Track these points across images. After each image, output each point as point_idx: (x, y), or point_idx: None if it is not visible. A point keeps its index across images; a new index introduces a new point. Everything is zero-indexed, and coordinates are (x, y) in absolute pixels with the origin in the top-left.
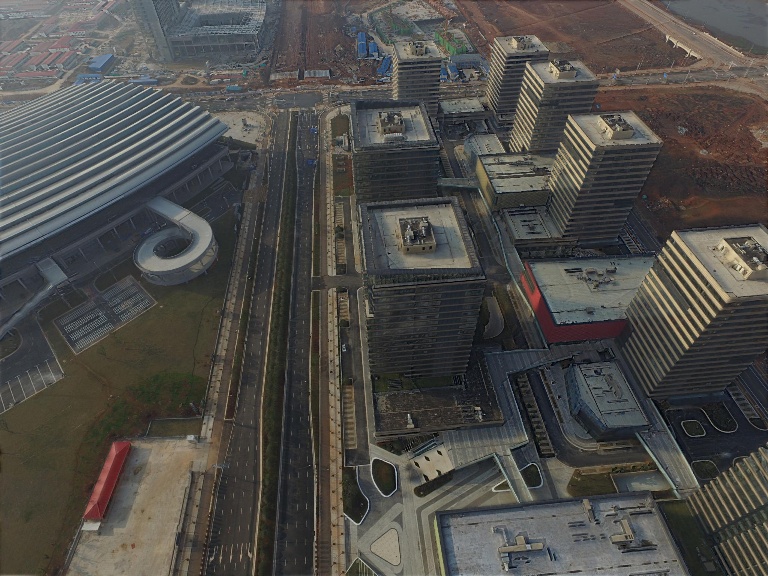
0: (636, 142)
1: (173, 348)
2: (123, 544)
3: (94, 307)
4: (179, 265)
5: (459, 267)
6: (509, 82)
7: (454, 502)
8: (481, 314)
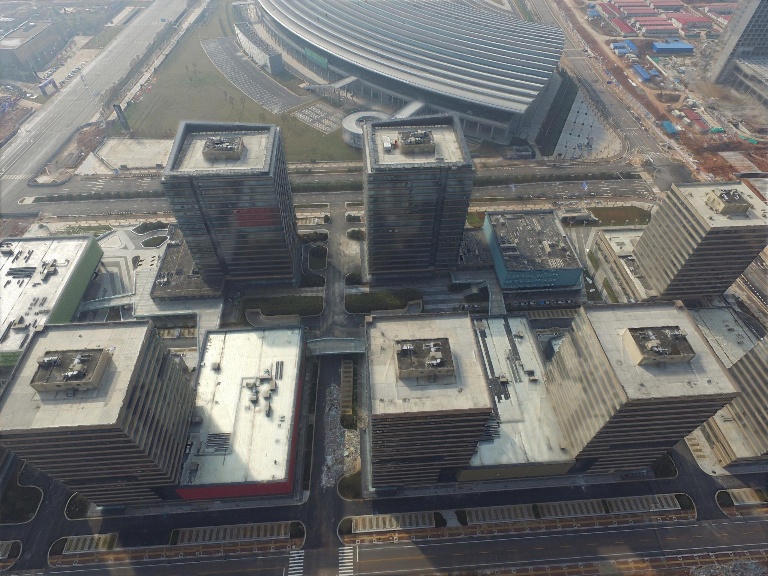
0: (382, 379)
1: (286, 146)
2: (168, 152)
3: (328, 112)
4: (347, 127)
5: (181, 170)
6: (759, 363)
7: (120, 274)
8: (267, 302)
